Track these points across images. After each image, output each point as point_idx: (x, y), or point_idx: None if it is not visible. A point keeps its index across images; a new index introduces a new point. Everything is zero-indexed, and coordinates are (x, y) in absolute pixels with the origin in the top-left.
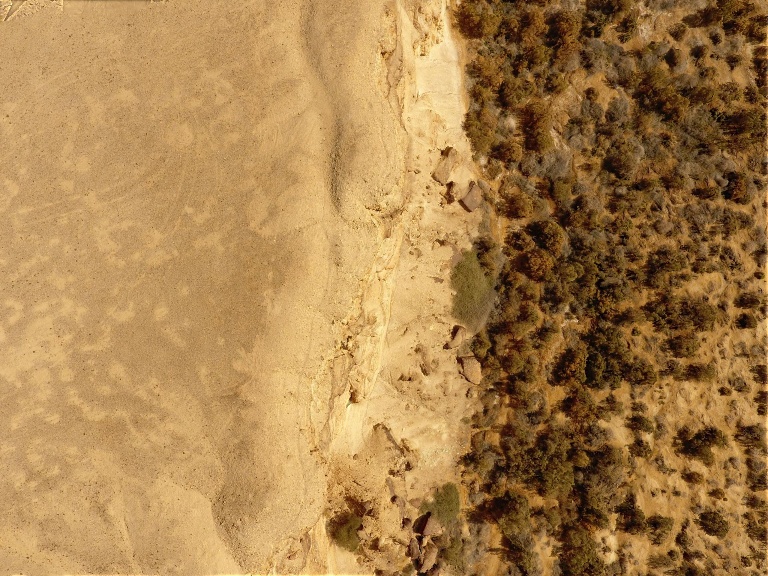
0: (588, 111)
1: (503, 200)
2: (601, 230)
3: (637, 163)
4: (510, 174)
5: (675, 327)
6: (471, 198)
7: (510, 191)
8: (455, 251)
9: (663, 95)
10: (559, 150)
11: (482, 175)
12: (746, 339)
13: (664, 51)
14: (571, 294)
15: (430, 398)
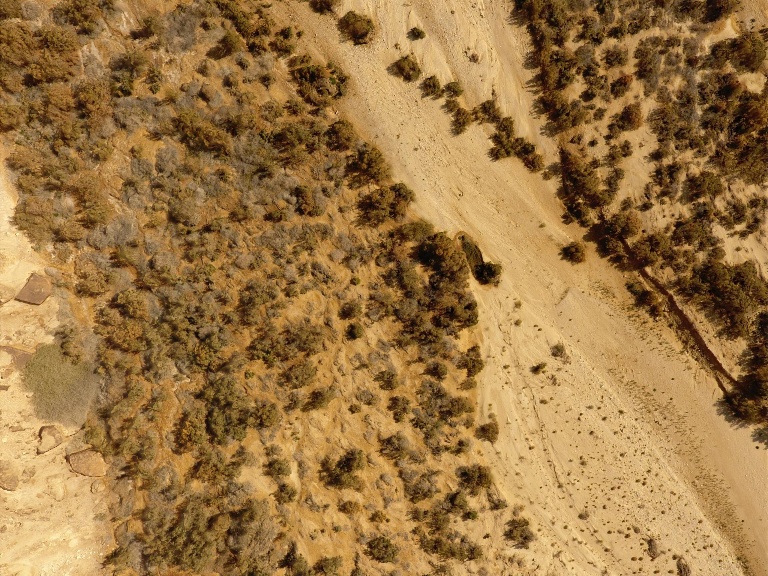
0: (138, 169)
1: (82, 280)
2: (182, 283)
3: (200, 206)
4: (82, 252)
5: (285, 358)
6: (30, 292)
7: (86, 269)
8: (13, 353)
9: (200, 134)
10: (123, 215)
11: (51, 262)
12: (361, 349)
13: (195, 90)
14: (166, 357)
15: (36, 510)
